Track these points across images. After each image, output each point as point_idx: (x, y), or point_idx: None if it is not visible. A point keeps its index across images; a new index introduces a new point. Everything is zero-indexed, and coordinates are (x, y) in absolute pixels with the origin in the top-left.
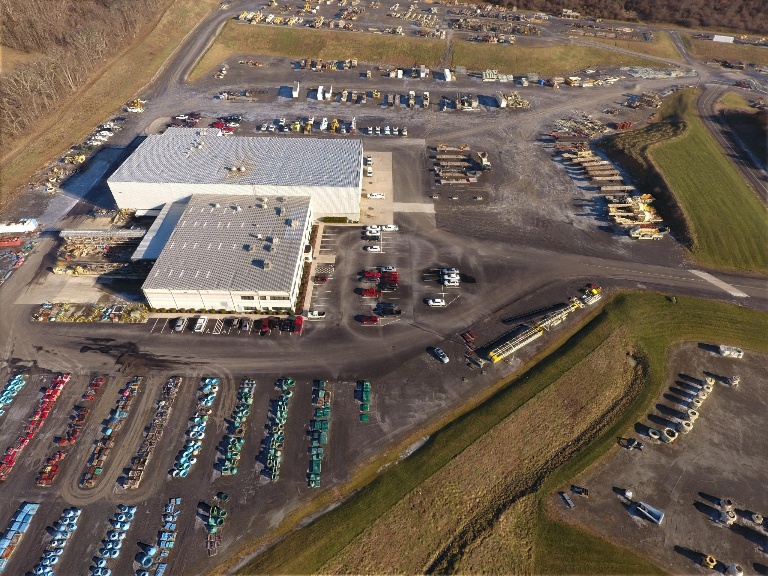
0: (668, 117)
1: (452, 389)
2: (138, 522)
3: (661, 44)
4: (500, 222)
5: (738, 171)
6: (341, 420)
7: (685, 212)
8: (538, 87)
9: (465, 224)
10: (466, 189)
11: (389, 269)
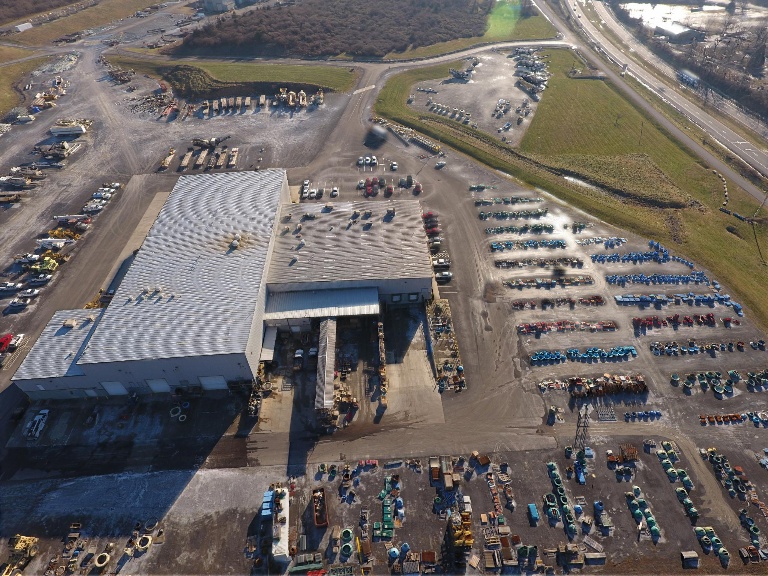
0: (159, 72)
1: (464, 162)
2: (597, 253)
3: (4, 49)
4: (298, 143)
5: (255, 64)
6: (500, 194)
7: (303, 82)
8: (44, 113)
9: (300, 156)
10: (246, 155)
11: (363, 182)
